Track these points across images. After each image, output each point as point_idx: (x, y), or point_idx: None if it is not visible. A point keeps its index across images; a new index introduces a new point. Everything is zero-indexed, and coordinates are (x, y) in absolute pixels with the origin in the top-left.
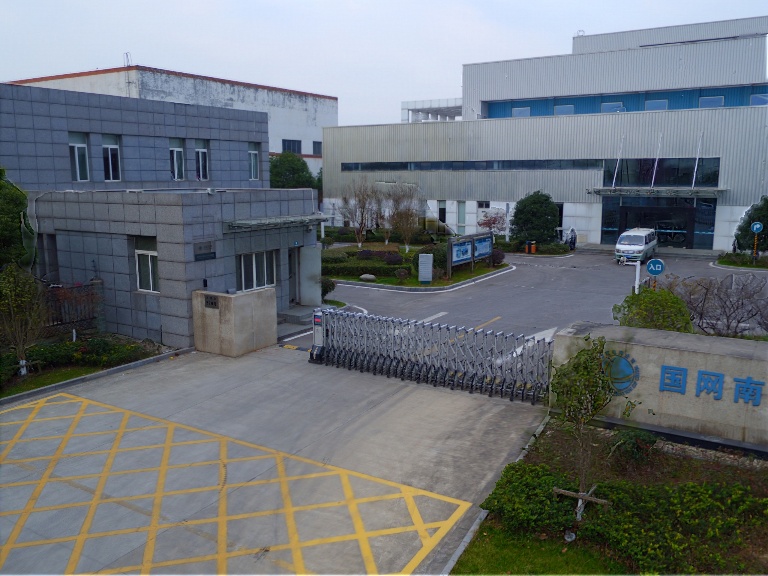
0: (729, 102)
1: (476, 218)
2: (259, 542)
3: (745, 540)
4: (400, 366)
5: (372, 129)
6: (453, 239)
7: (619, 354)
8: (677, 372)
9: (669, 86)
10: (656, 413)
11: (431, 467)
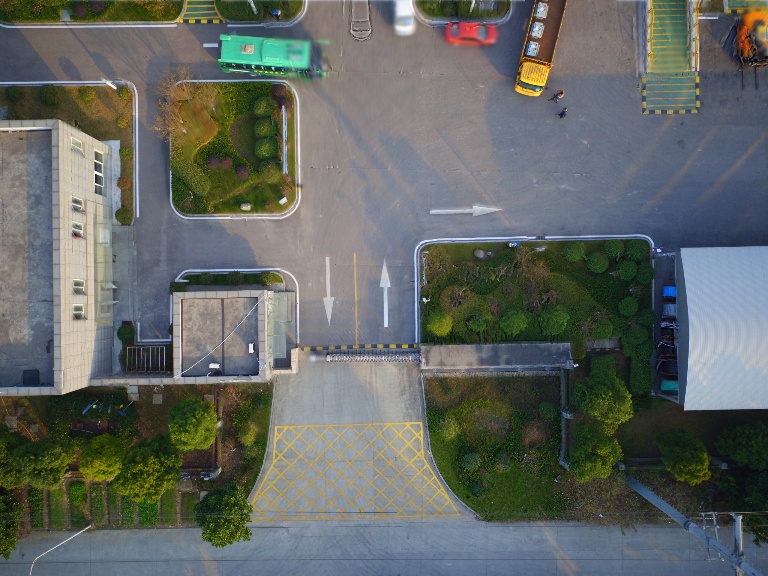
0: None
1: None
2: (393, 456)
3: None
4: None
5: None
6: None
7: None
8: None
9: None
10: None
11: (406, 412)
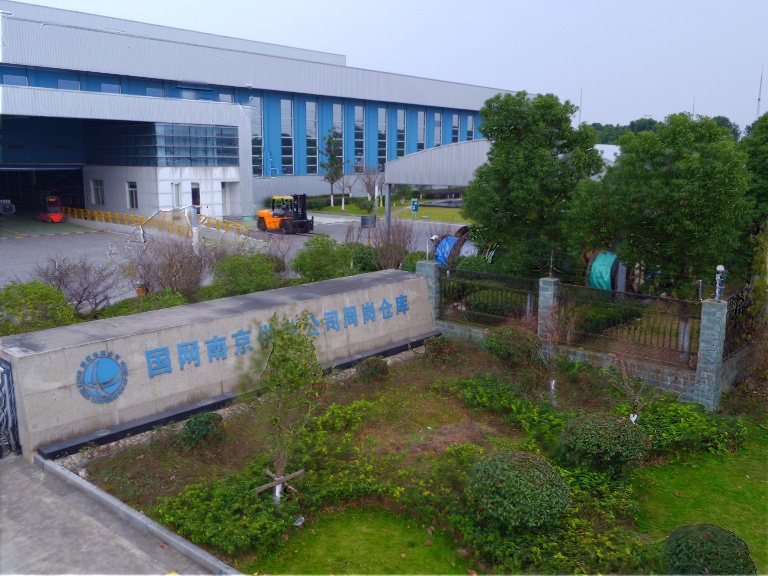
0: None
1: None
2: None
3: None
4: None
5: None
6: None
7: (101, 355)
8: (161, 353)
9: None
10: (152, 402)
11: None
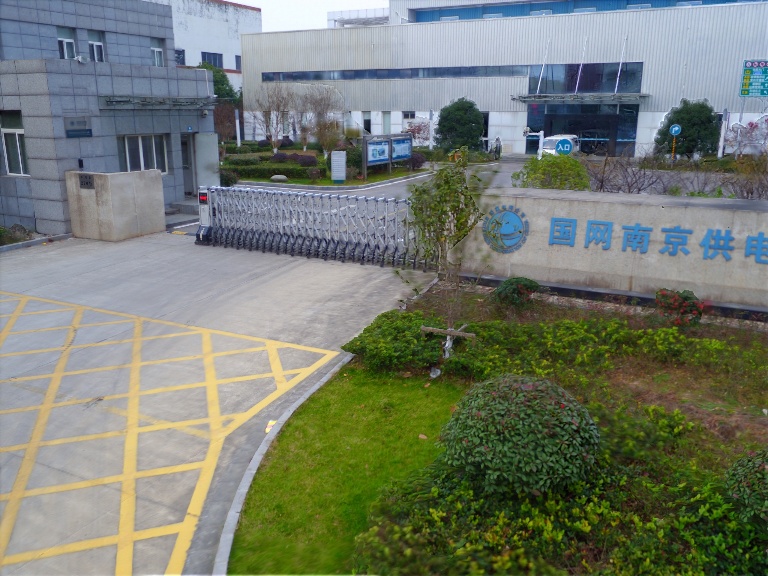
0: None
1: (401, 129)
2: (94, 393)
3: (617, 369)
4: (290, 242)
5: (293, 35)
6: (368, 137)
7: (509, 209)
8: (566, 224)
9: None
10: (545, 268)
11: (303, 324)
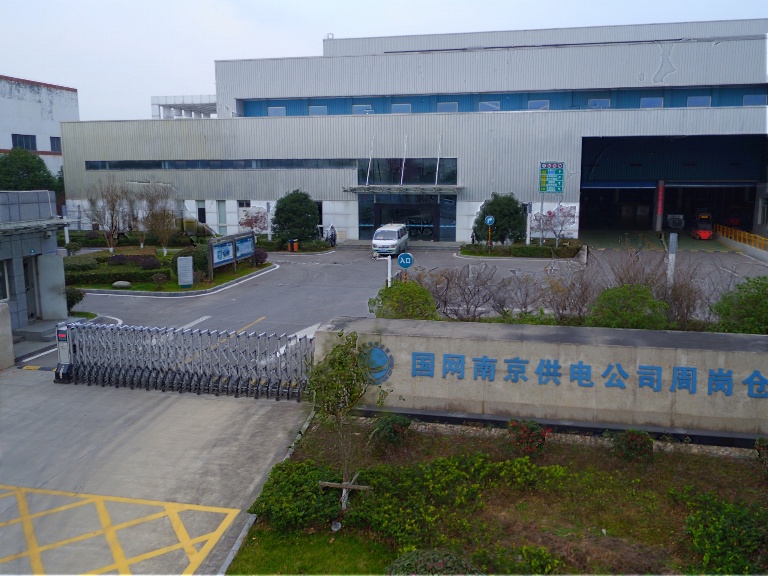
0: (462, 108)
1: (237, 218)
2: None
3: (487, 502)
4: (160, 377)
5: (119, 125)
6: (213, 240)
7: (375, 345)
8: (426, 357)
9: (411, 91)
10: (410, 397)
11: (197, 479)
